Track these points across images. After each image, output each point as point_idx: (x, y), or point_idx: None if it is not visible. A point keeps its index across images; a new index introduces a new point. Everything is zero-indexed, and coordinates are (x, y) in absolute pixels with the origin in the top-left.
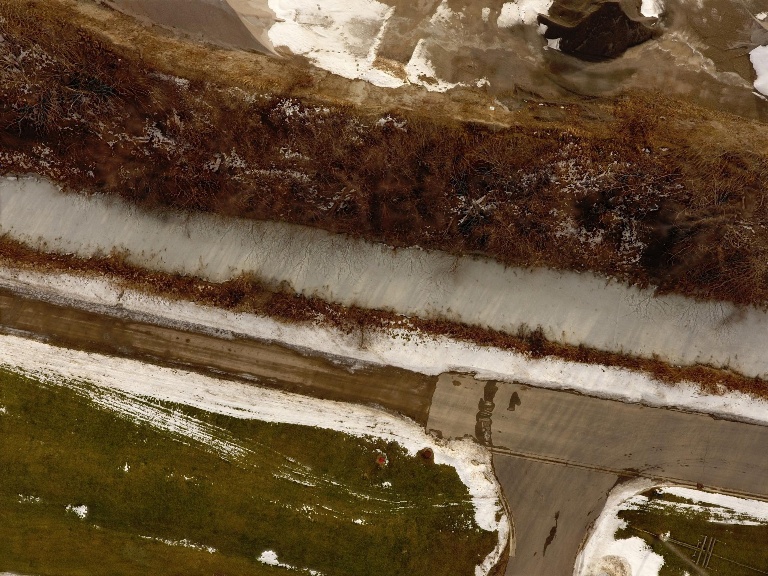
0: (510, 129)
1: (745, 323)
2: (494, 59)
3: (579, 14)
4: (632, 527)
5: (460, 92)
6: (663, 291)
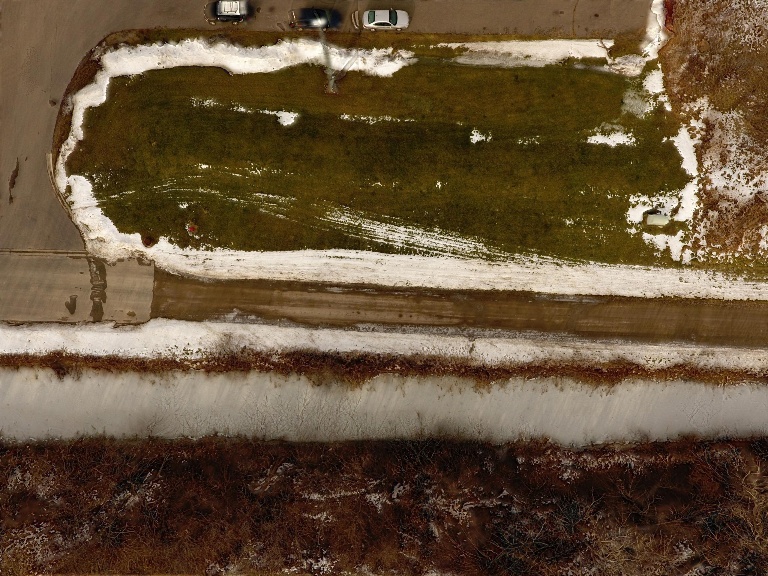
0: None
1: None
2: None
3: None
4: None
5: None
6: None
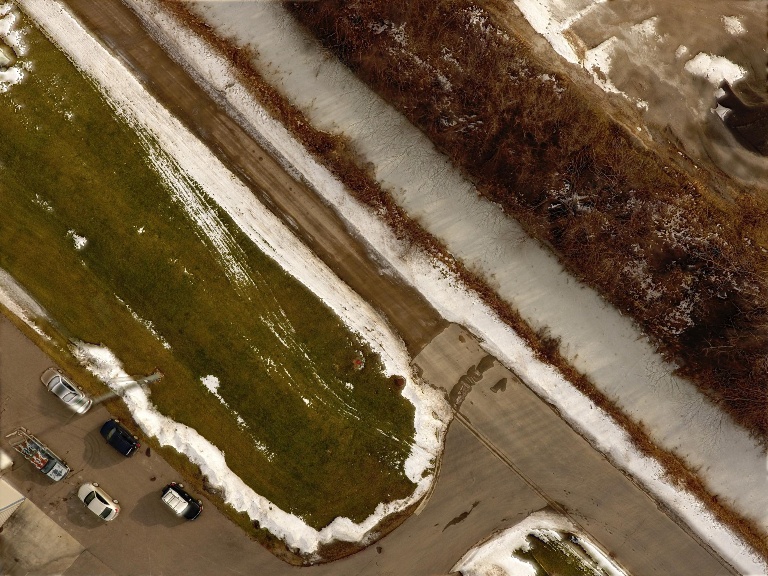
0: (647, 151)
1: (733, 445)
2: (664, 92)
3: (759, 98)
4: (533, 554)
5: (620, 100)
6: (682, 374)
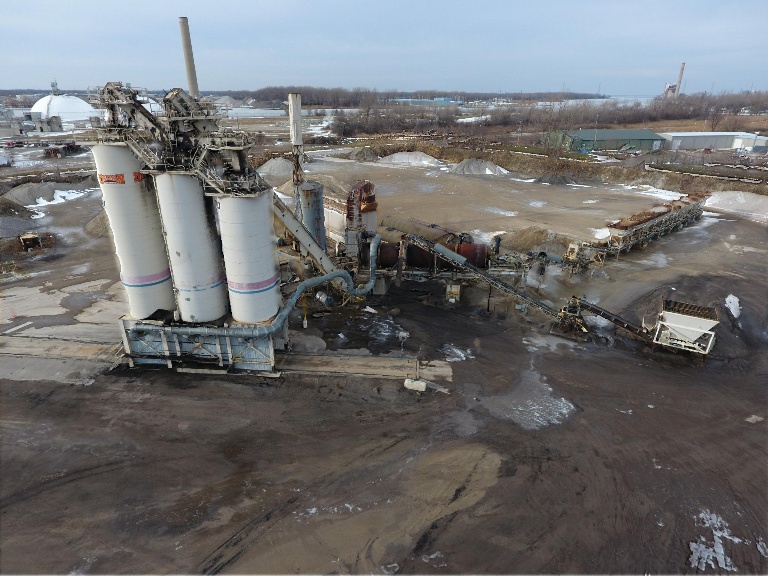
0: None
1: None
2: None
3: None
4: None
5: None
6: None
